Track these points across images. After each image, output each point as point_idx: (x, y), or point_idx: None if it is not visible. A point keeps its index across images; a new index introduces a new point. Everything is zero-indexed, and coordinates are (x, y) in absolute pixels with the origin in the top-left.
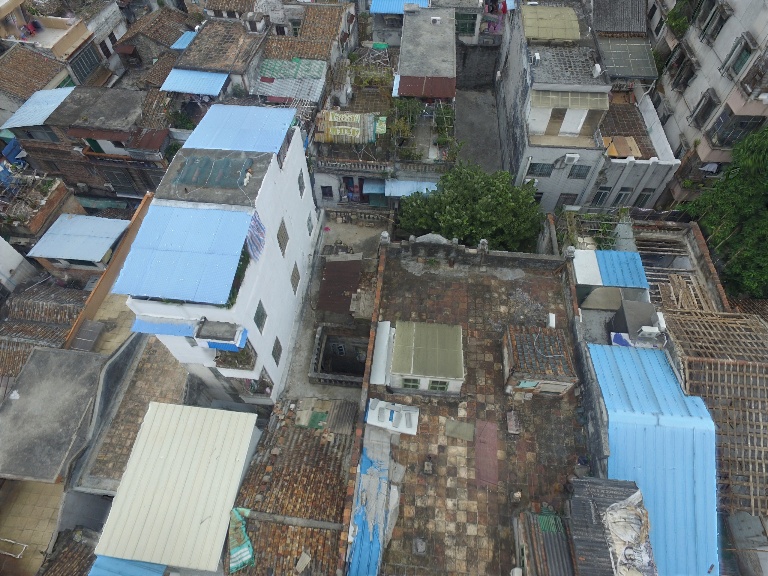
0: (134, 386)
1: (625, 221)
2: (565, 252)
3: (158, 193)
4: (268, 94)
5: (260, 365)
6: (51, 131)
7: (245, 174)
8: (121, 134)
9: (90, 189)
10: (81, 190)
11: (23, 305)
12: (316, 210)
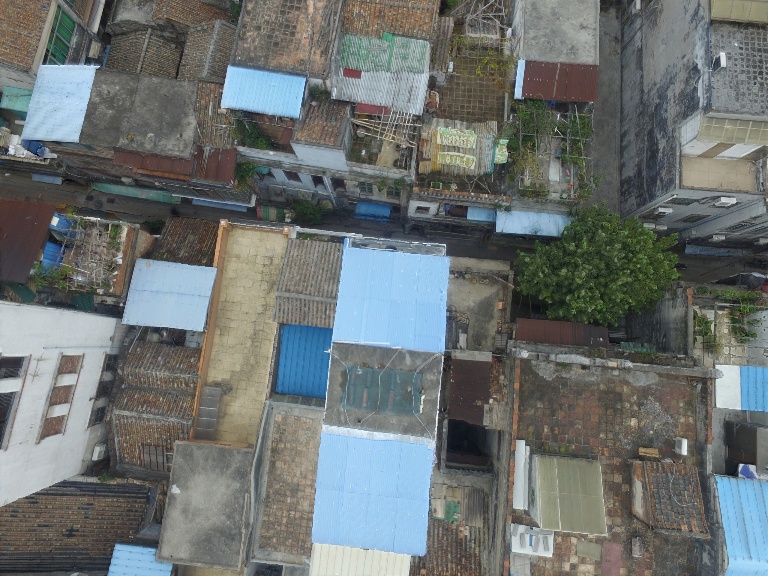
0: (274, 467)
1: None
2: (710, 373)
3: (328, 421)
4: (356, 100)
5: None
6: (87, 145)
7: (419, 399)
8: (182, 163)
9: (136, 181)
10: (127, 184)
11: (136, 374)
12: None
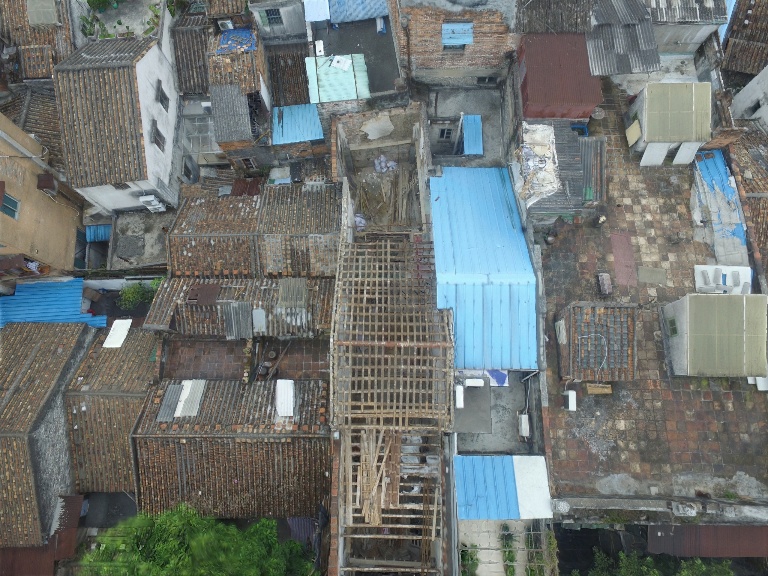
0: None
1: None
2: None
3: None
4: None
5: None
6: None
7: None
8: None
9: None
10: None
11: None
12: None
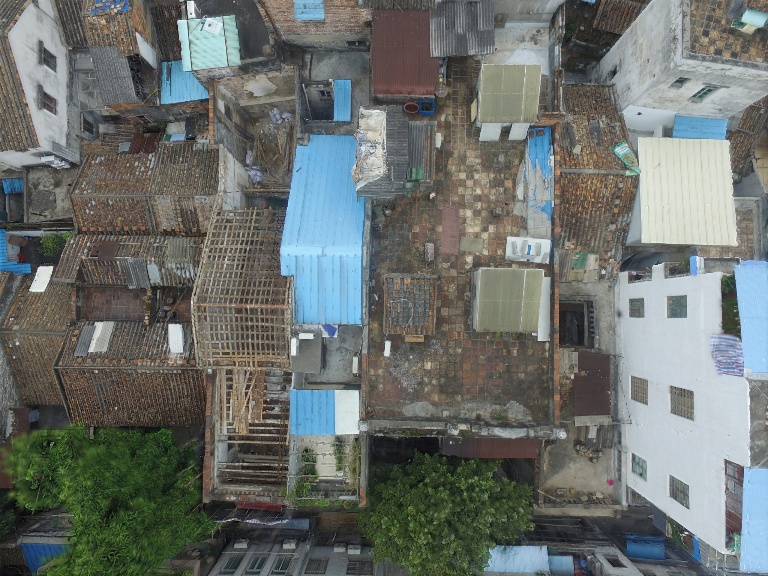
0: None
1: (294, 479)
2: None
3: None
4: None
5: (656, 276)
6: None
7: None
8: None
9: None
10: None
11: None
12: (633, 502)
